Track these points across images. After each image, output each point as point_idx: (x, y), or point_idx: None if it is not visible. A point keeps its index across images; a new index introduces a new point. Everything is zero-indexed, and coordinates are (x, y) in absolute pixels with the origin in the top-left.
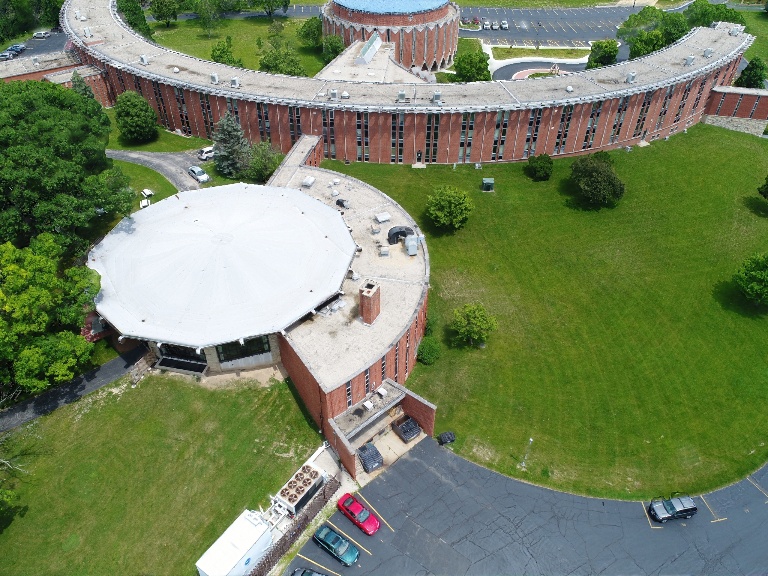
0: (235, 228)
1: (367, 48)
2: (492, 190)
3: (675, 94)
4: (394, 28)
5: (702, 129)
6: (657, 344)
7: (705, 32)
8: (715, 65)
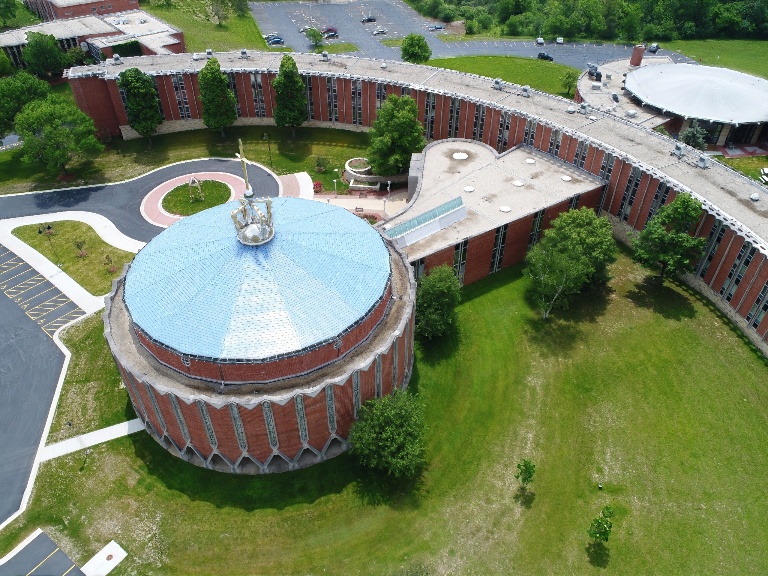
0: (700, 85)
1: None
2: None
3: None
4: None
5: None
6: (483, 74)
7: None
8: None
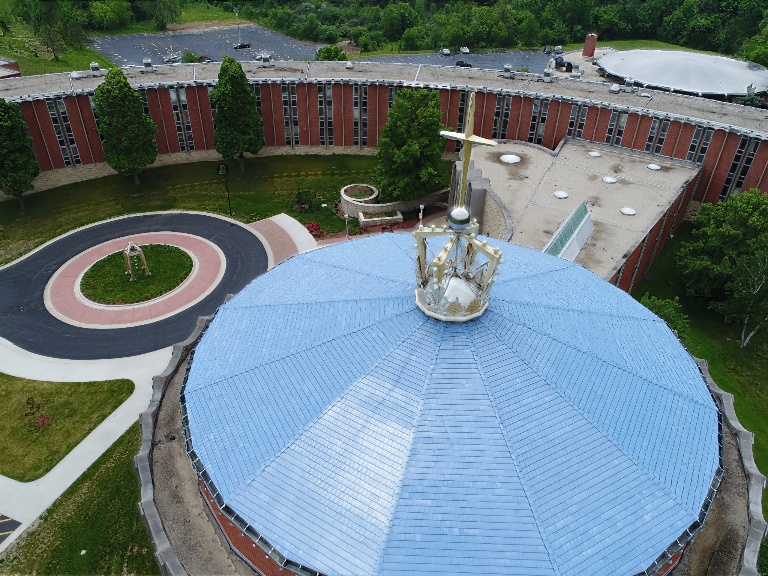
0: (683, 63)
1: None
2: None
3: None
4: None
5: None
6: None
7: None
8: None
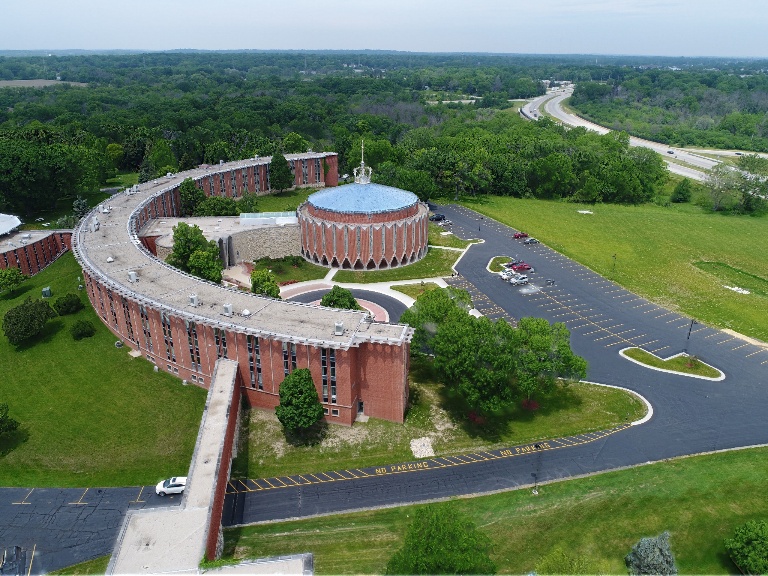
0: None
1: (259, 216)
2: (44, 297)
3: (151, 318)
4: (309, 215)
5: (197, 396)
6: None
7: (341, 316)
8: (196, 318)
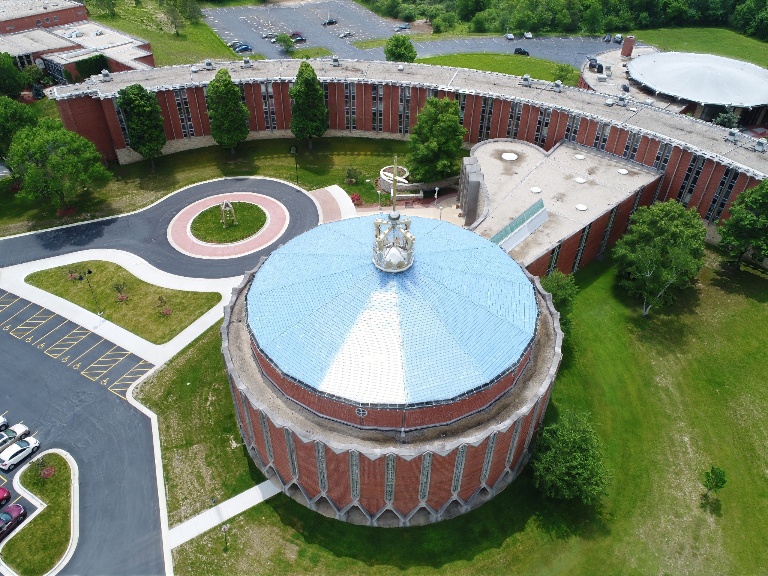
0: (702, 71)
1: None
2: None
3: None
4: None
5: None
6: None
7: None
8: None
